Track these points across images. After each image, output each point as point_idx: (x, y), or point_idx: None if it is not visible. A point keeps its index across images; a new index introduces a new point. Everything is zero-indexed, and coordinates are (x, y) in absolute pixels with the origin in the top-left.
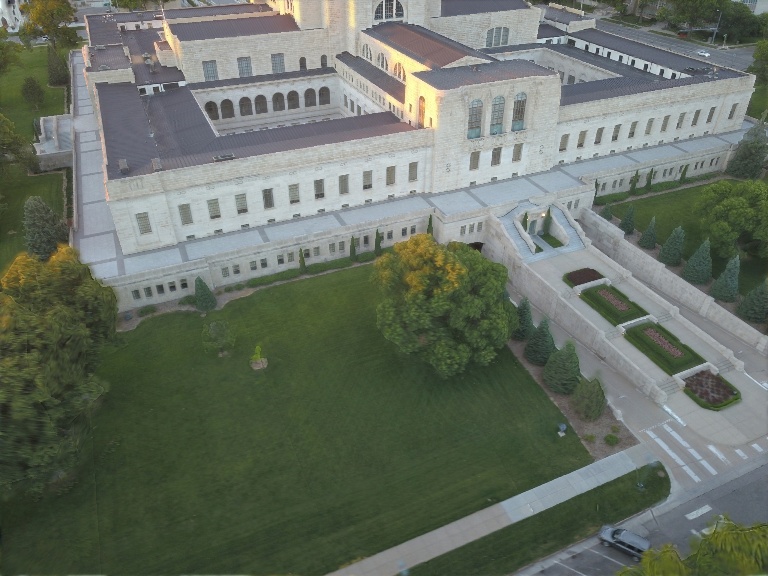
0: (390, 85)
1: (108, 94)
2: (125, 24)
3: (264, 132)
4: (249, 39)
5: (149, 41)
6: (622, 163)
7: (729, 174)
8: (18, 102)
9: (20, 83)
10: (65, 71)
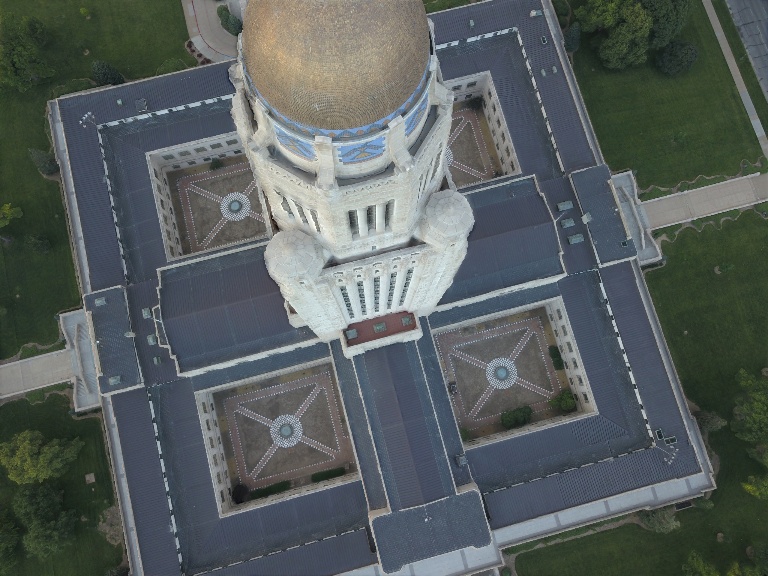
0: (366, 451)
1: (126, 423)
2: (106, 123)
3: (256, 512)
4: (243, 359)
5: (140, 189)
6: (544, 524)
7: (639, 517)
8: (21, 223)
9: (9, 162)
10: (53, 161)
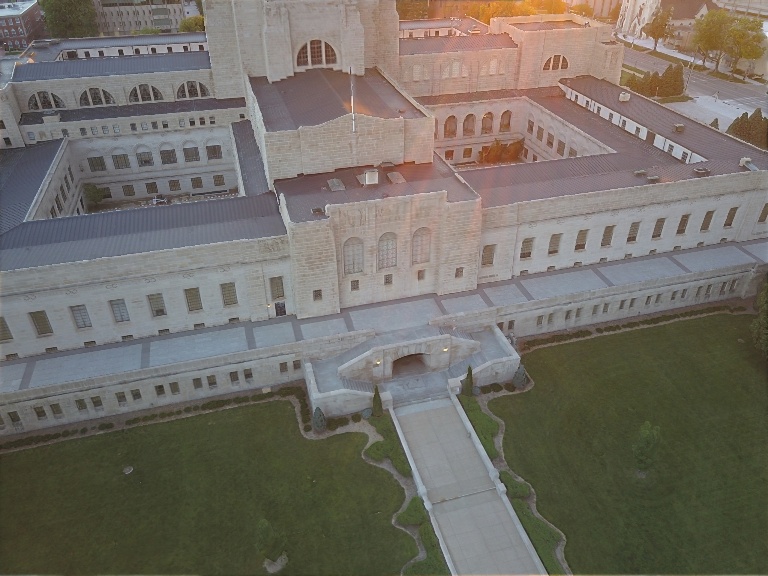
0: None
1: (203, 35)
2: None
3: None
4: None
5: None
6: None
7: None
8: None
9: None
10: None
